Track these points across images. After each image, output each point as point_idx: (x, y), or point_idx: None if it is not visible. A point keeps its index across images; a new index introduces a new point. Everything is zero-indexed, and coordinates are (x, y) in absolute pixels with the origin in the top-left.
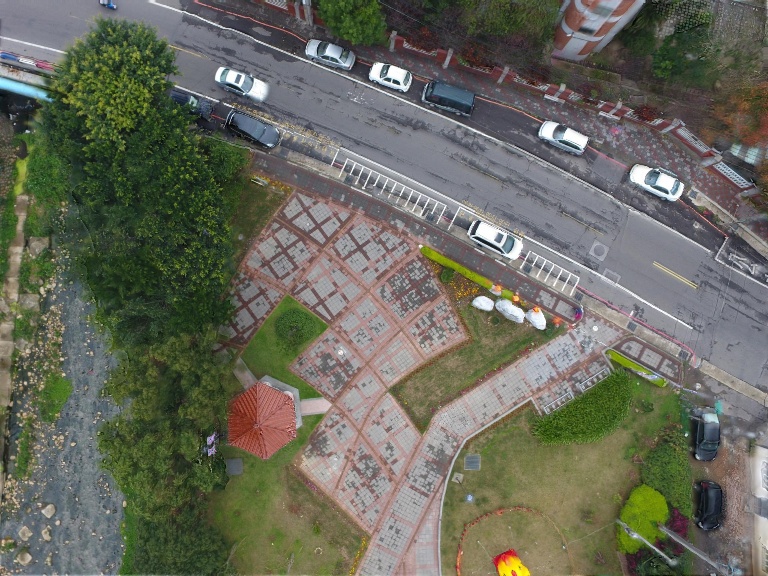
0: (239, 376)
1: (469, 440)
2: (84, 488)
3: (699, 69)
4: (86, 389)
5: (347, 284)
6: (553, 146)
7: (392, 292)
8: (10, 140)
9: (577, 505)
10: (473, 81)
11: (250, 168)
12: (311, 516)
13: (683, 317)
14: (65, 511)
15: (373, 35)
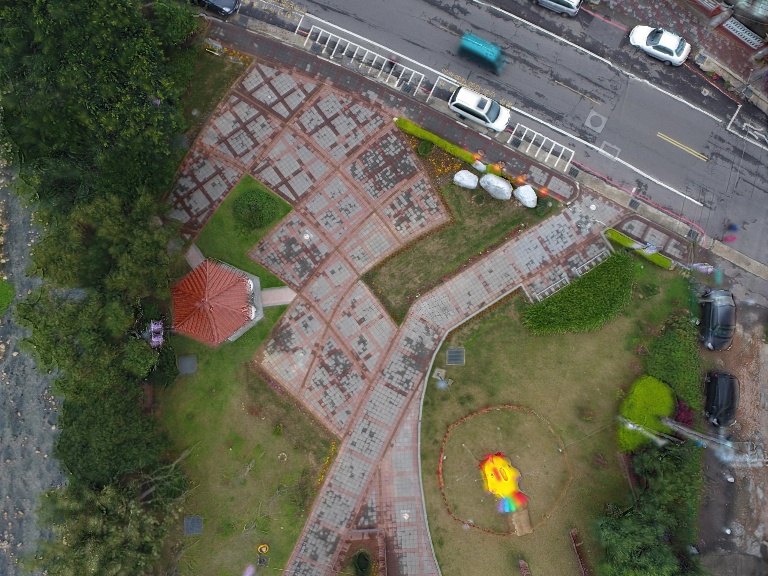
0: (193, 263)
1: (452, 332)
2: (27, 402)
3: None
4: (29, 293)
5: (313, 161)
6: (543, 8)
7: (364, 170)
8: None
9: (575, 403)
10: None
11: (205, 37)
12: (274, 418)
13: (692, 193)
14: (6, 427)
15: None
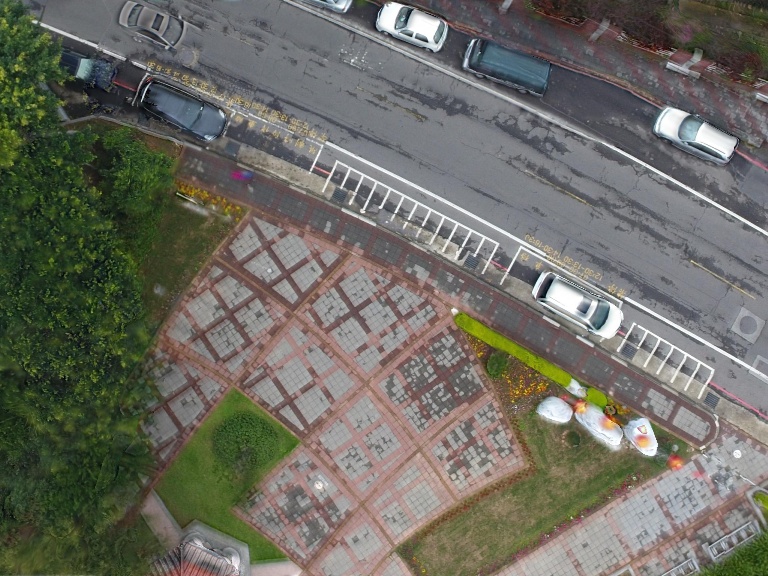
0: (151, 520)
1: None
2: None
3: None
4: None
5: (332, 372)
6: (678, 149)
7: (406, 386)
8: None
9: None
10: (549, 36)
11: (175, 173)
12: None
13: None
14: None
15: None
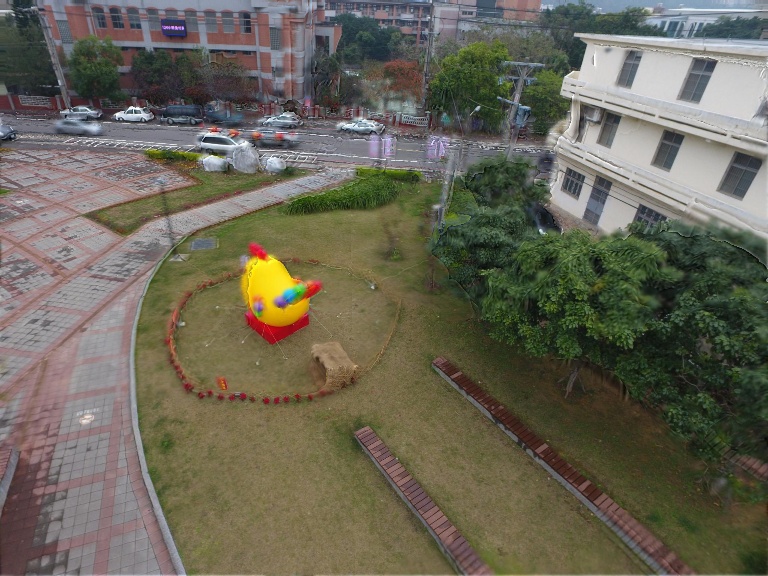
0: None
1: (200, 230)
2: None
3: (360, 87)
4: None
5: (52, 173)
6: (276, 127)
7: None
8: None
9: (374, 251)
10: None
11: None
12: None
13: None
14: None
15: (111, 75)
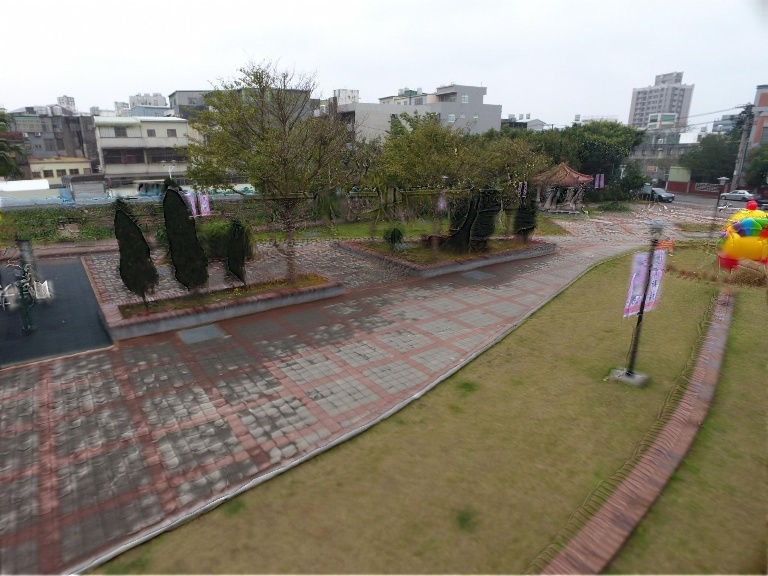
0: None
1: None
2: None
3: None
4: None
5: None
6: None
7: None
8: None
9: None
10: None
11: None
12: None
13: None
14: None
15: None
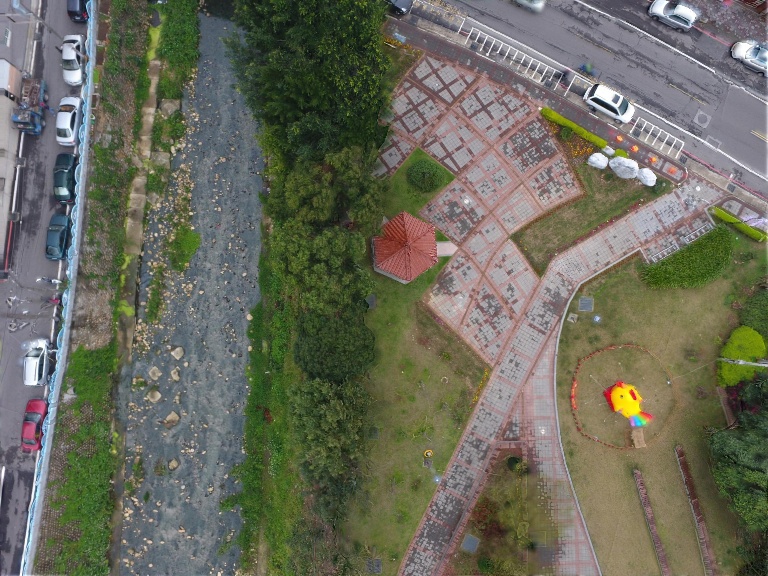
0: None
1: (583, 284)
2: (211, 333)
3: None
4: (214, 242)
5: (473, 140)
6: (661, 23)
7: (514, 149)
8: (145, 7)
9: (681, 345)
10: None
11: (383, 32)
12: (438, 348)
13: None
14: (193, 354)
15: None
